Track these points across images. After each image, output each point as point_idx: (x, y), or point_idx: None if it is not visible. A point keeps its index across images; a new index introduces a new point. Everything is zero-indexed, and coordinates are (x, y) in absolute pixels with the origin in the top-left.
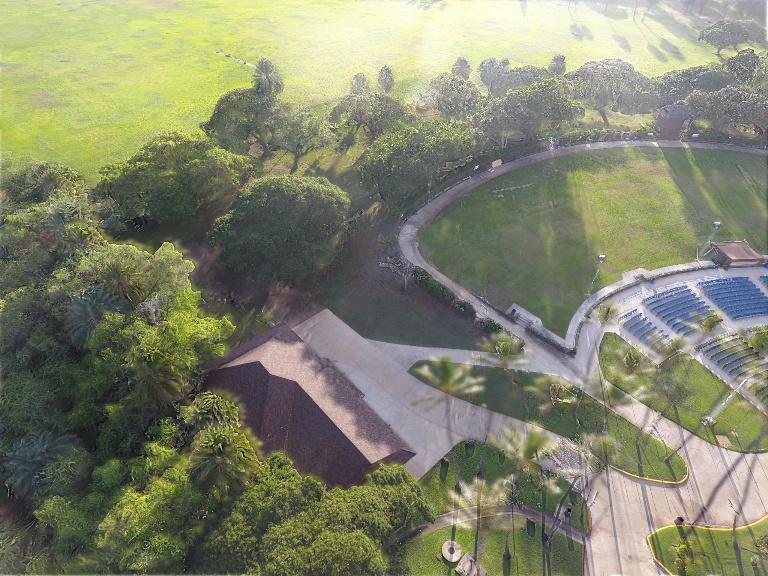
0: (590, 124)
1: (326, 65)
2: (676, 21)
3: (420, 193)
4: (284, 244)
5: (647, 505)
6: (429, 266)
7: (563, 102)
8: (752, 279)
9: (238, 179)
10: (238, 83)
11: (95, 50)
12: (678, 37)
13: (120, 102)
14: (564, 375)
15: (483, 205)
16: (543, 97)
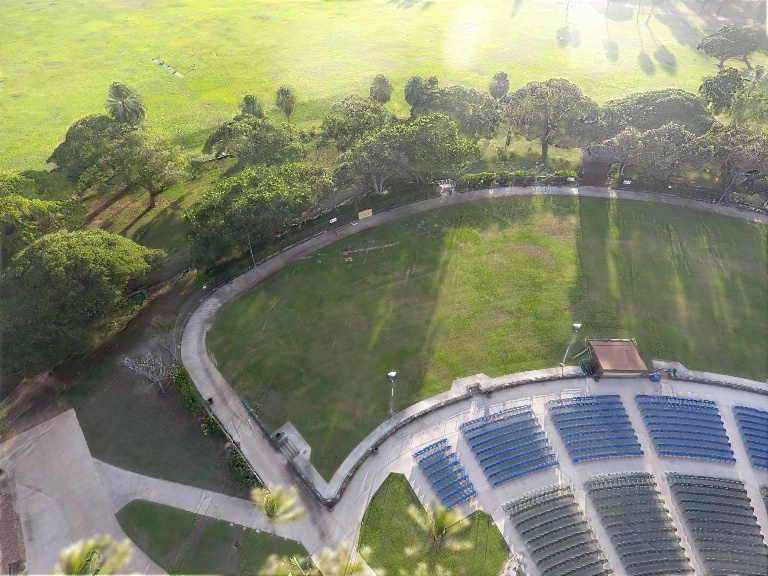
0: (523, 157)
1: (259, 76)
2: (687, 23)
3: (241, 256)
4: (27, 327)
5: None
6: (207, 360)
7: (443, 144)
8: (626, 398)
9: (34, 232)
10: (152, 97)
11: (30, 56)
12: (681, 43)
13: (16, 118)
14: (305, 540)
15: (320, 272)
16: (418, 138)
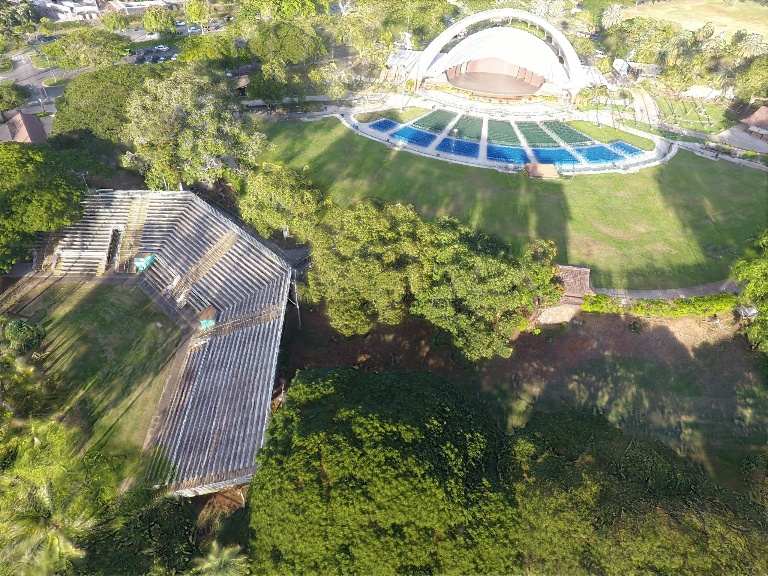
0: None
1: None
2: None
3: None
4: None
5: None
6: None
7: None
8: None
9: None
10: None
11: None
12: None
13: None
14: (675, 141)
15: None
16: None
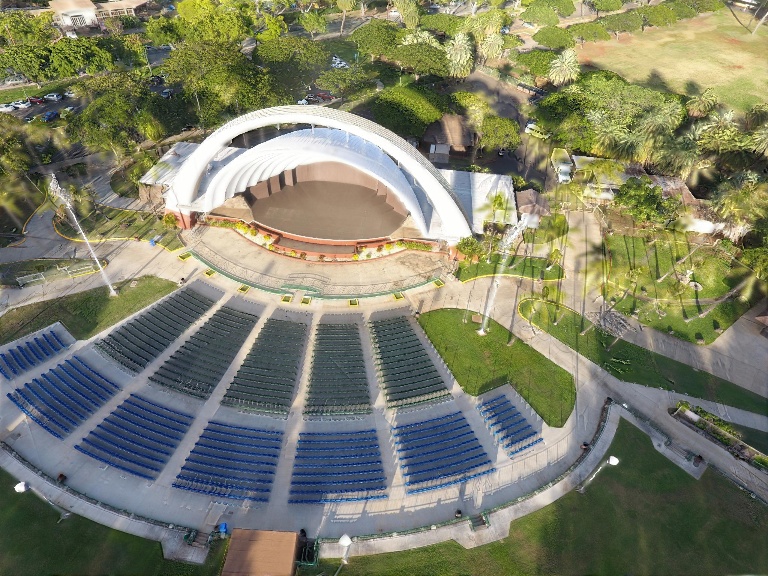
0: None
1: None
2: None
3: None
4: None
5: (559, 292)
6: None
7: None
8: (278, 504)
9: None
10: None
11: None
12: None
13: None
14: (619, 382)
15: None
16: None
